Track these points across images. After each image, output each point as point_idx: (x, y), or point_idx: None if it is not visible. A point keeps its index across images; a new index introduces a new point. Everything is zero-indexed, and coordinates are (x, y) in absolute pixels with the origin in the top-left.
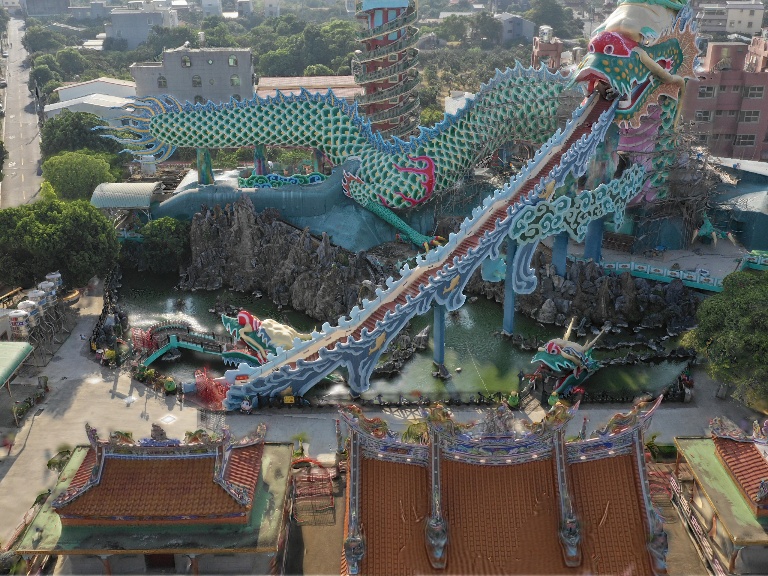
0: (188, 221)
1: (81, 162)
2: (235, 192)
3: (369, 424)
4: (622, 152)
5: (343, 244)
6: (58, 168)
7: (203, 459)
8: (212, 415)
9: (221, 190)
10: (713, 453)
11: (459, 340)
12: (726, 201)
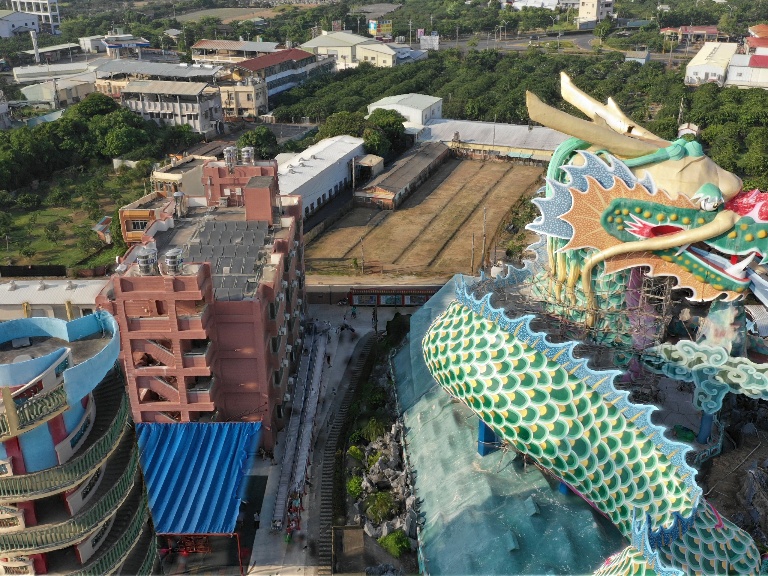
0: None
1: None
2: None
3: None
4: None
5: None
6: None
7: None
8: None
9: None
10: None
11: None
12: None
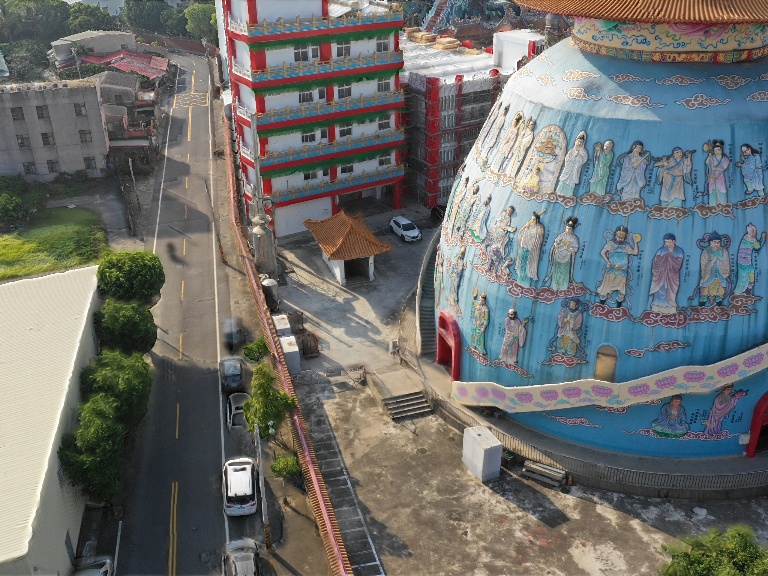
0: None
1: (208, 7)
2: None
3: (509, 10)
4: None
5: None
6: (200, 11)
7: (476, 24)
8: None
9: None
10: None
11: None
12: (488, 2)
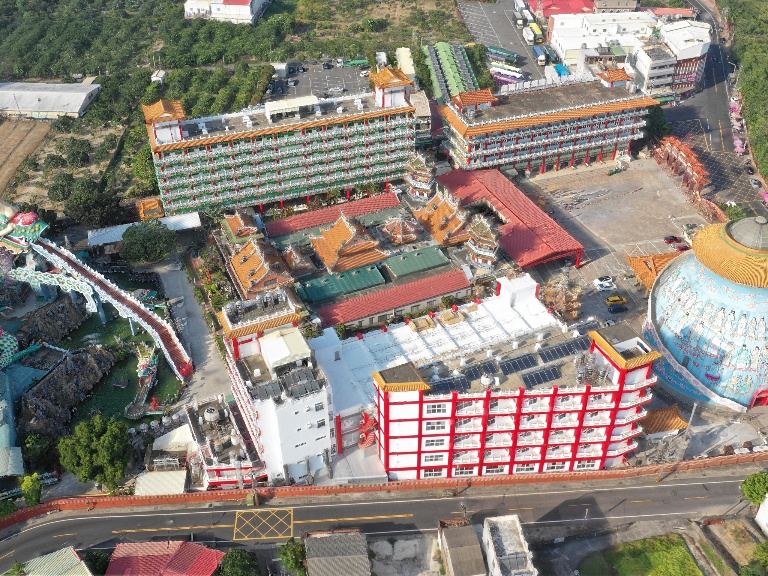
0: (26, 434)
1: None
2: (8, 409)
3: None
4: (18, 257)
5: (41, 374)
6: None
7: None
8: (197, 369)
9: (7, 414)
10: (237, 239)
11: (115, 333)
12: None
